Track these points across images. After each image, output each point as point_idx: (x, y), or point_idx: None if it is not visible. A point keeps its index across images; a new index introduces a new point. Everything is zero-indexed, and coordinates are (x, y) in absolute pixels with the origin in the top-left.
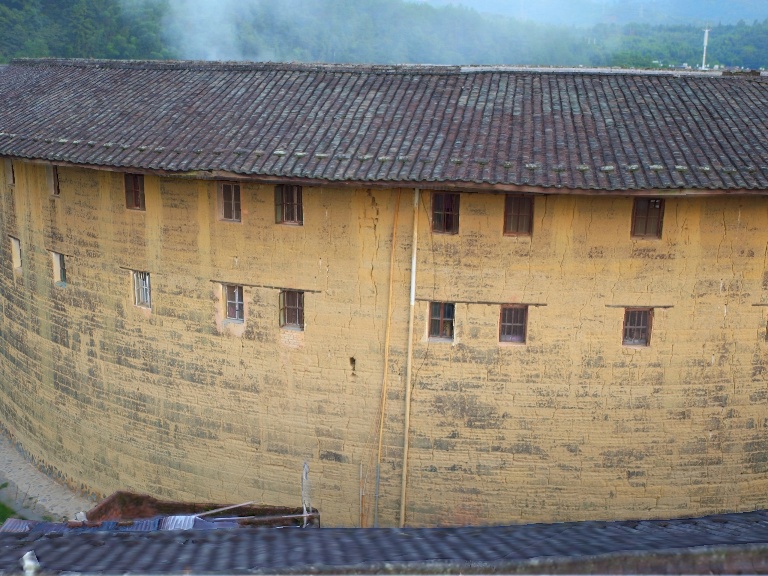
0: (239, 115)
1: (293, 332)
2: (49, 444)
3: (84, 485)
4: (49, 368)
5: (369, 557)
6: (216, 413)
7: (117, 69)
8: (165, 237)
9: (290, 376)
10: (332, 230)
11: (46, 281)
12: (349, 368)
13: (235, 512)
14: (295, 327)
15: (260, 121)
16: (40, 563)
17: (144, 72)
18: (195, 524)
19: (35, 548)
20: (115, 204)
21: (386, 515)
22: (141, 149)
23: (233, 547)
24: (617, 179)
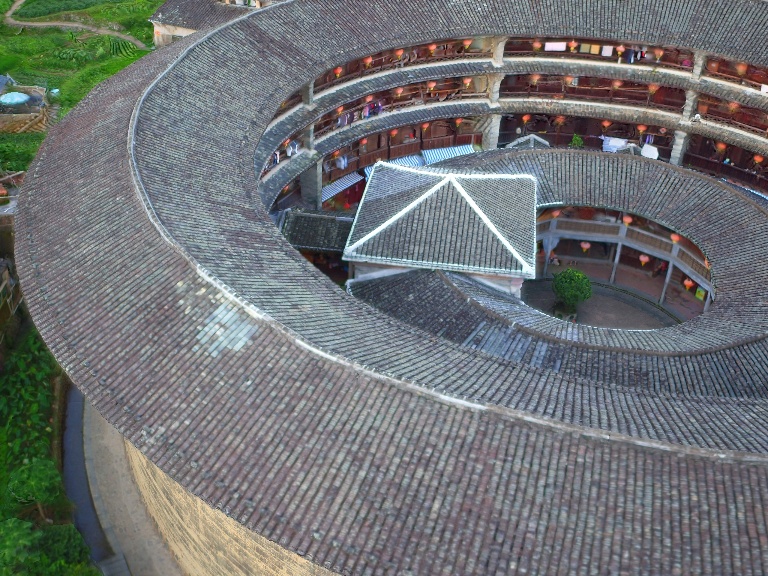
0: None
1: None
2: None
3: None
4: None
5: None
6: None
7: None
8: None
9: None
10: None
11: None
12: None
13: None
14: None
15: None
16: None
17: None
18: None
19: None
20: None
21: None
22: None
23: None
24: (37, 159)
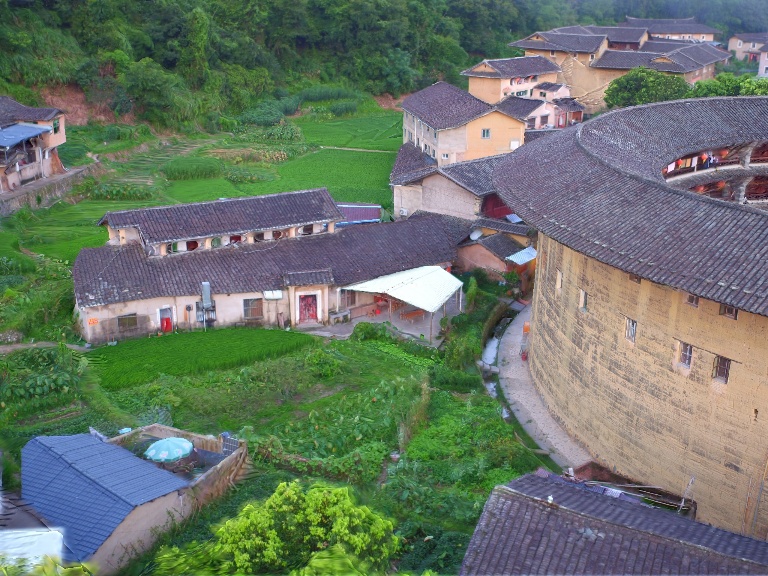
0: (705, 246)
1: (720, 383)
2: (560, 403)
3: (577, 435)
4: (568, 357)
5: (682, 536)
6: (664, 418)
7: (640, 182)
8: (650, 304)
9: (714, 409)
10: (755, 327)
11: (574, 305)
12: (753, 415)
13: (651, 490)
14: (722, 380)
15: (717, 255)
16: (553, 497)
17: (656, 190)
18: (620, 496)
19: (551, 489)
20: (623, 275)
21: (763, 514)
22: (640, 261)
23: (630, 513)
24: None
